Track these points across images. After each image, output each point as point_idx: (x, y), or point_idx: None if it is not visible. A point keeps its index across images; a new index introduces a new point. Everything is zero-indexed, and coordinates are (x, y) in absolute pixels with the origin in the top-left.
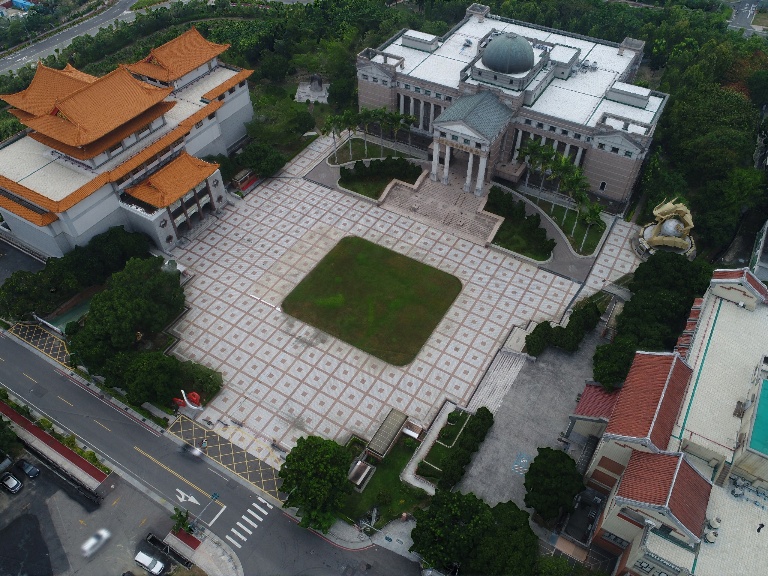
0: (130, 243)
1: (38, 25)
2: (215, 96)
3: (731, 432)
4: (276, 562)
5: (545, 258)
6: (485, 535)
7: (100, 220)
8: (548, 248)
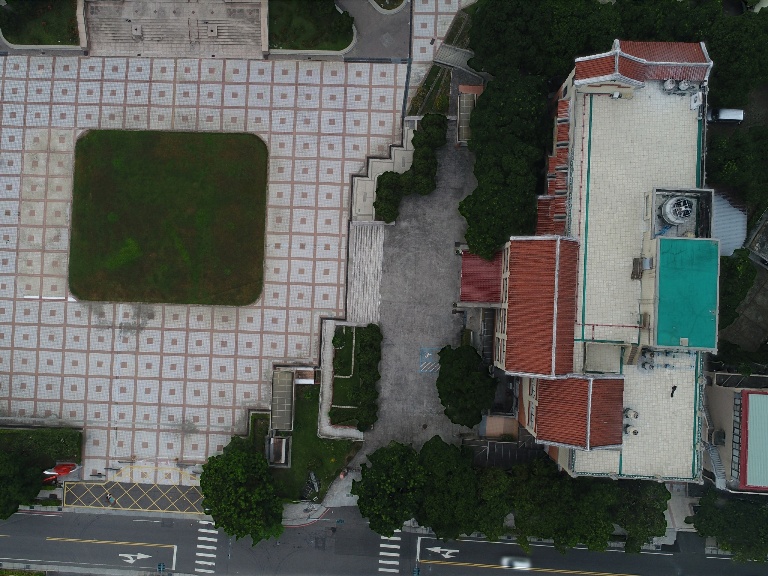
0: None
1: None
2: None
3: (632, 303)
4: (253, 568)
5: (348, 41)
6: (425, 493)
7: None
8: (346, 29)
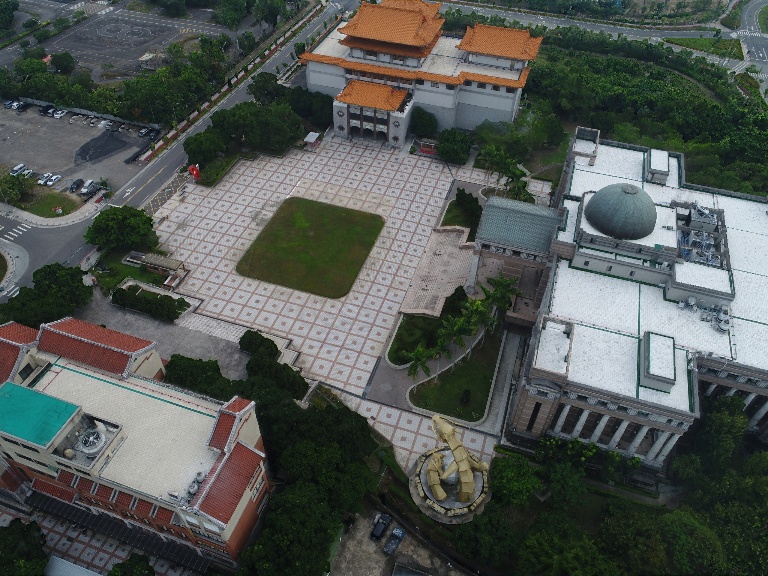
0: (316, 106)
1: (583, 9)
2: (471, 79)
3: None
4: (79, 234)
5: (393, 360)
6: (41, 292)
7: (328, 86)
8: None
